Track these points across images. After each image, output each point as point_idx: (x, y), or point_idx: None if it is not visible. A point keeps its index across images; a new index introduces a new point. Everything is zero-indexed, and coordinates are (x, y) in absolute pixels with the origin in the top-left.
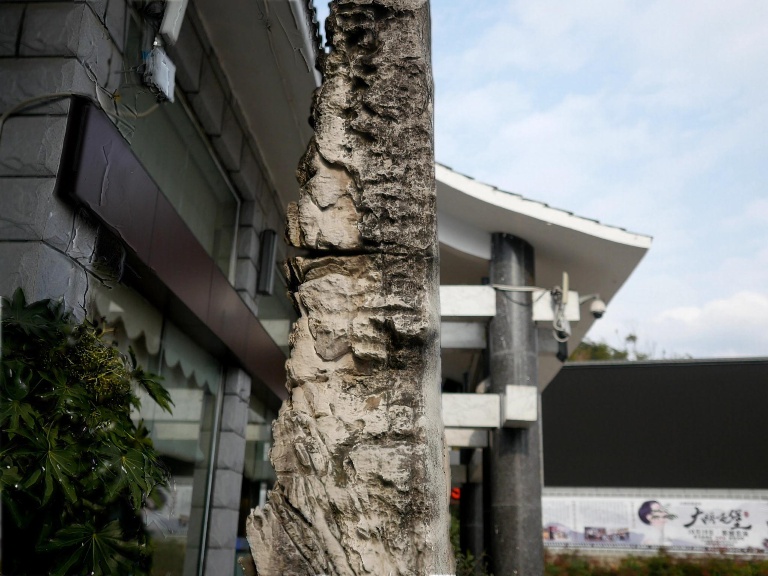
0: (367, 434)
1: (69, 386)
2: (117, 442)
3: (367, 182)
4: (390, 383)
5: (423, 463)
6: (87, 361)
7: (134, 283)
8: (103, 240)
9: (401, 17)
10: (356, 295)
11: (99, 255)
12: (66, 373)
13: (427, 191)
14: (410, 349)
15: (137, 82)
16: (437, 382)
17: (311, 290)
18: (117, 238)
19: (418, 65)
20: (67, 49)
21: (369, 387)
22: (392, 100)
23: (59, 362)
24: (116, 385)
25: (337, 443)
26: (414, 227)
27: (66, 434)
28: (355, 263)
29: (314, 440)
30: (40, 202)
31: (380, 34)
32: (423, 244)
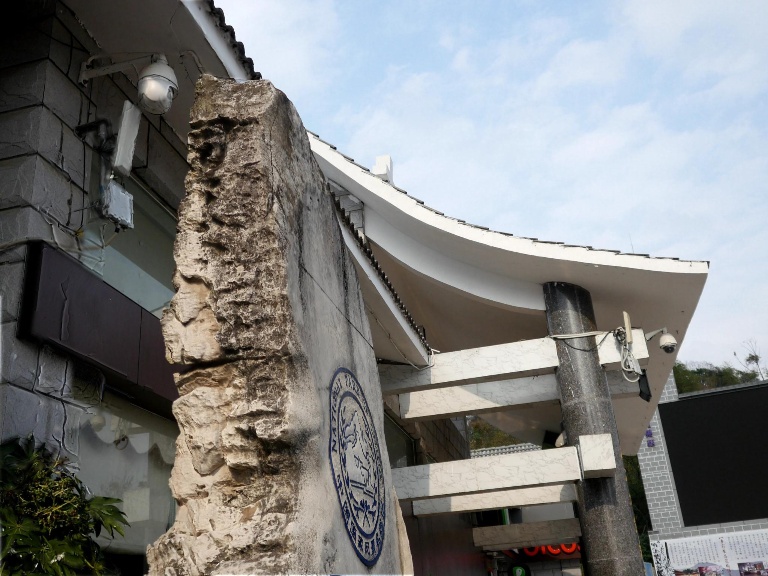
0: (233, 549)
1: (21, 524)
2: (70, 574)
3: (221, 291)
4: (267, 490)
5: (283, 574)
6: (40, 496)
7: (126, 404)
8: (75, 371)
9: (245, 125)
10: (223, 405)
11: (72, 386)
12: (17, 512)
13: (276, 291)
14: (278, 453)
15: (99, 215)
16: (324, 480)
17: (182, 406)
18: (92, 366)
19: (258, 169)
20: (22, 200)
21: (249, 496)
22: (237, 207)
23: (11, 502)
24: (72, 516)
25: (208, 562)
26: (269, 329)
27: (17, 573)
28: (222, 373)
29: (185, 562)
30: (5, 346)
31: (228, 145)
32: (277, 345)
